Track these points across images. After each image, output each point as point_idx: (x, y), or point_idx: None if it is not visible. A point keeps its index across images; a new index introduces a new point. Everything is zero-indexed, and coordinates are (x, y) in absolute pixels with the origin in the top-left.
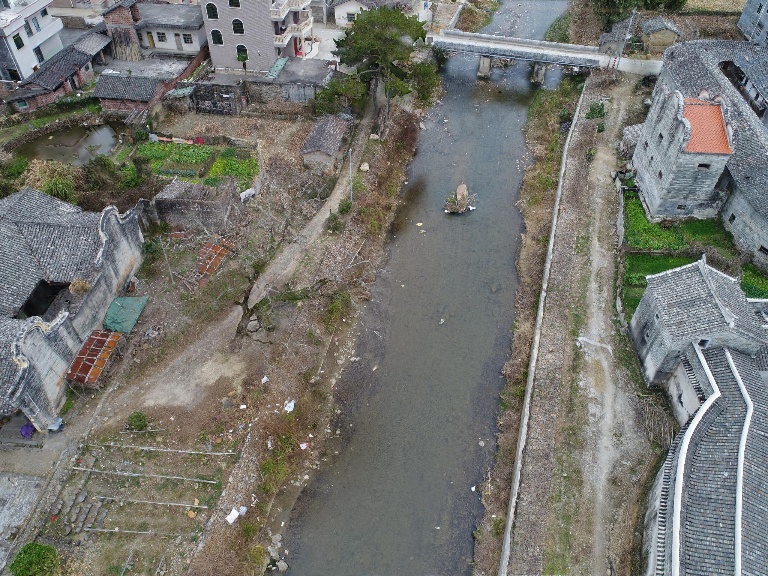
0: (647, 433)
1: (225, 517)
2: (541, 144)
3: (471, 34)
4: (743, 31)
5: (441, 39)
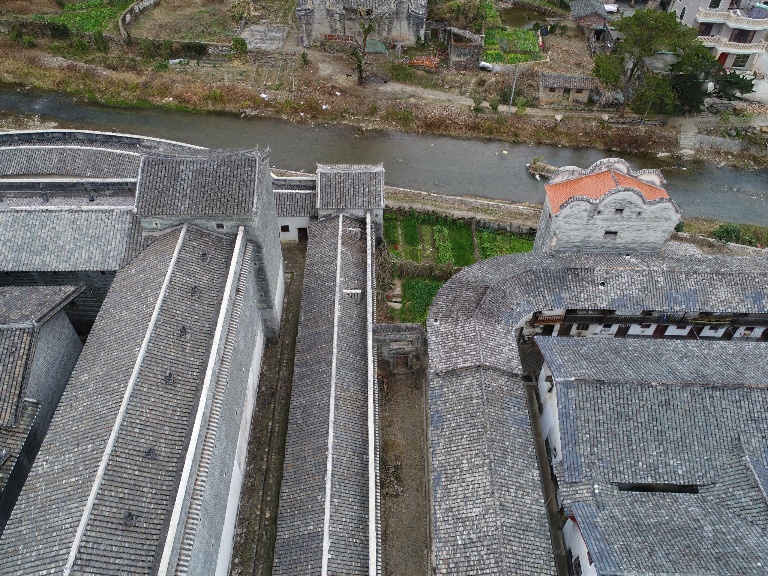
0: None
1: (263, 93)
2: None
3: None
4: None
5: None
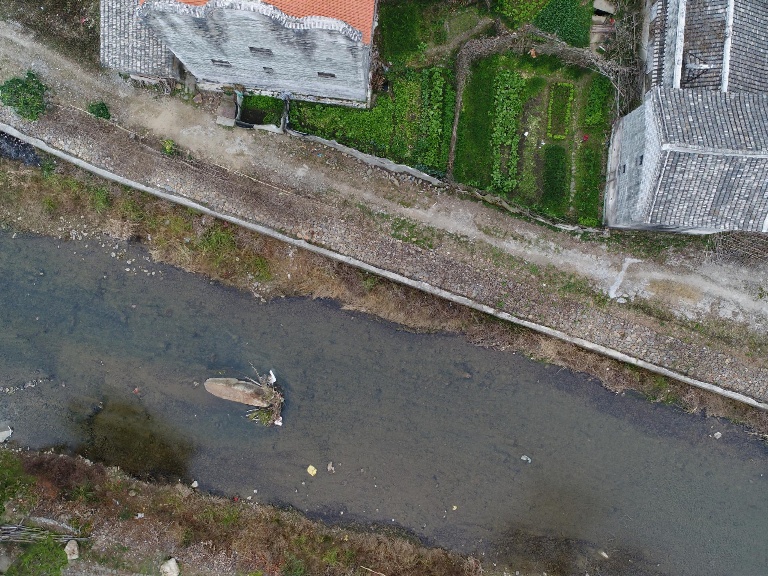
0: (765, 259)
1: None
2: (76, 213)
3: None
4: None
5: None
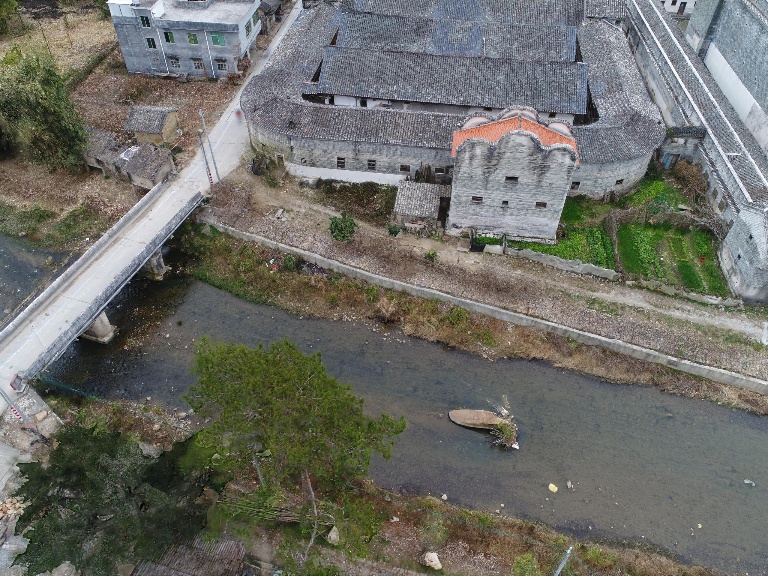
0: None
1: None
2: (349, 304)
3: (23, 315)
4: (147, 73)
5: (1, 366)
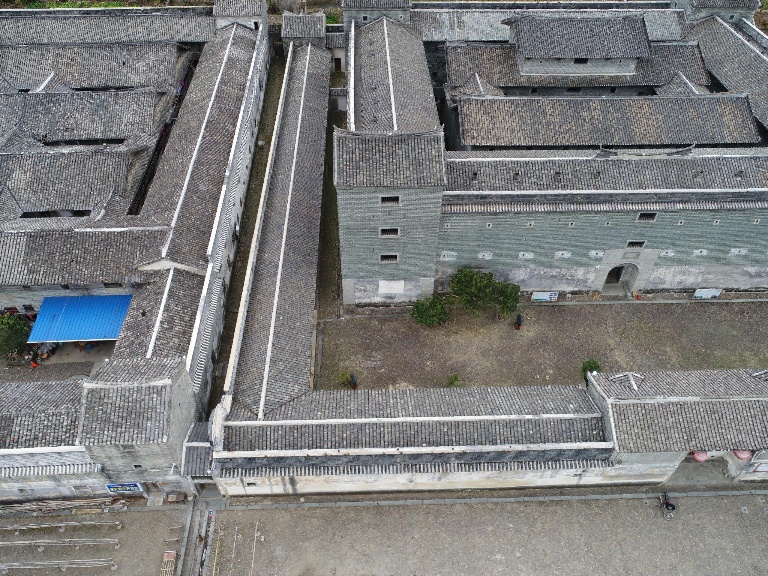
0: None
1: None
2: None
3: None
4: None
5: None
